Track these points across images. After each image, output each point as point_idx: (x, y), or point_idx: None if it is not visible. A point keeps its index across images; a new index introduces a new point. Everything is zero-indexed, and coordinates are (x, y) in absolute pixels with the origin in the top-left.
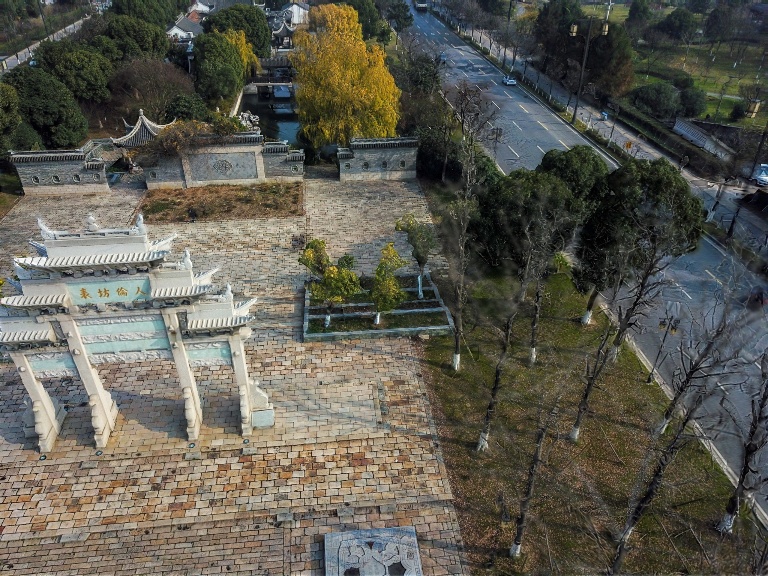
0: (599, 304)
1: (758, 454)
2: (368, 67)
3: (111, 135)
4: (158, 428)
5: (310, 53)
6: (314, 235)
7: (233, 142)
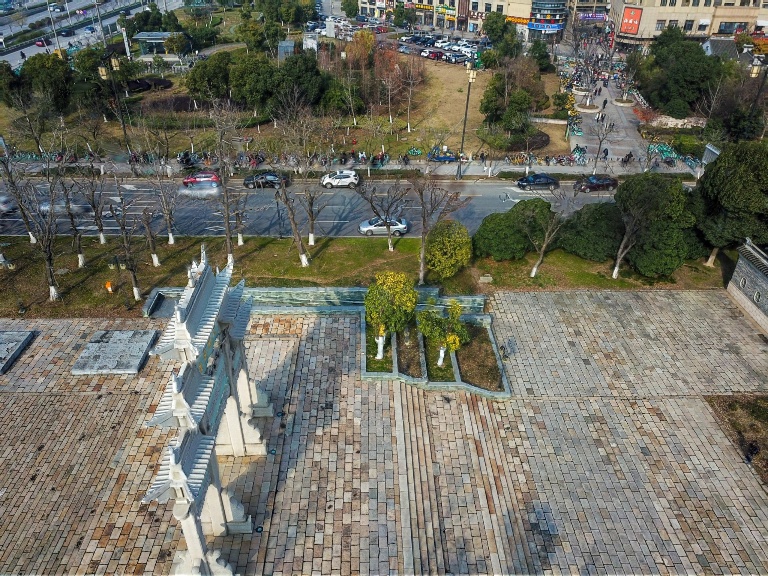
0: None
1: None
2: None
3: None
4: None
5: None
6: None
7: None
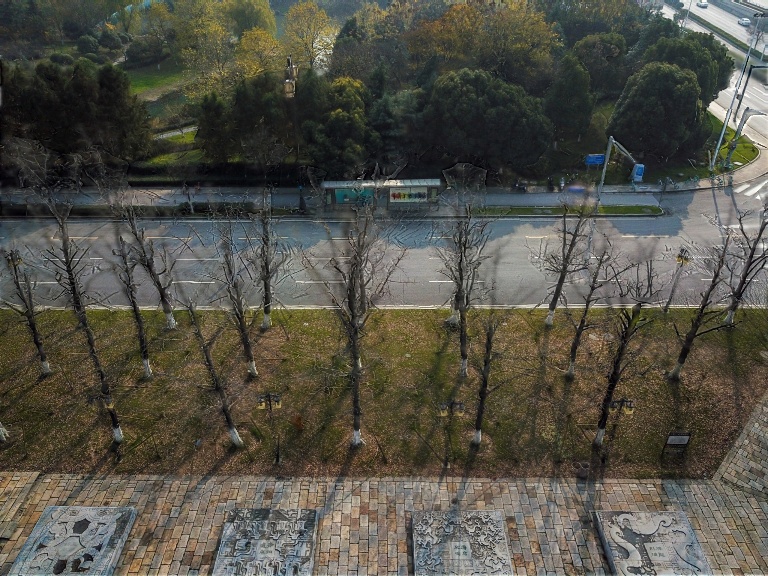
0: None
1: (154, 265)
2: None
3: None
4: None
5: None
6: None
7: None
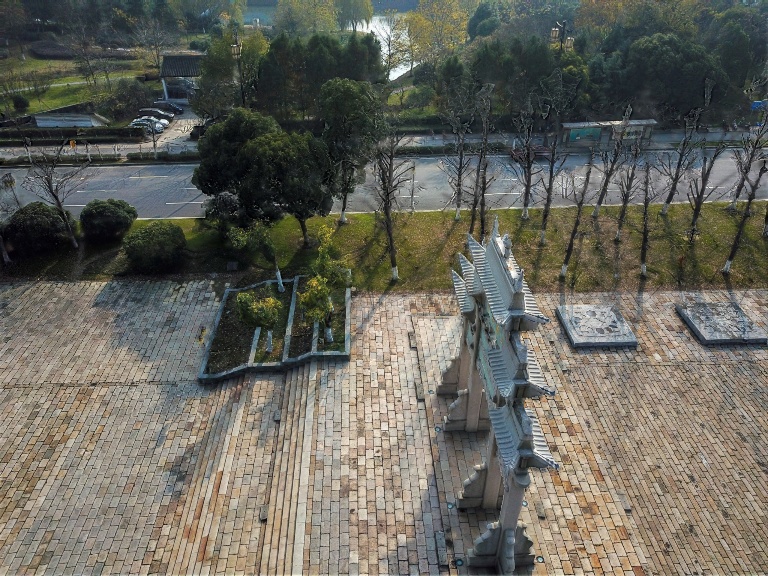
0: None
1: None
2: None
3: None
4: (483, 458)
5: None
6: (65, 379)
7: None
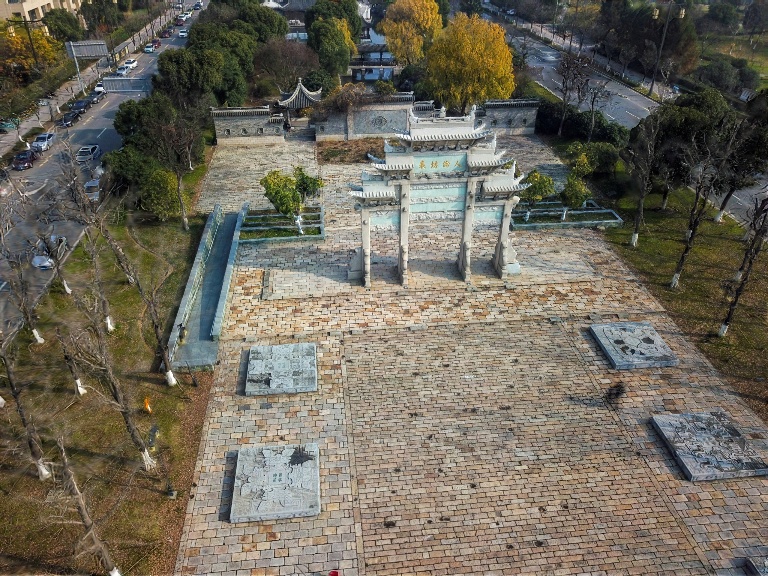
0: (731, 205)
1: None
2: (492, 42)
3: (249, 105)
4: (438, 275)
5: (405, 38)
6: None
7: (391, 101)
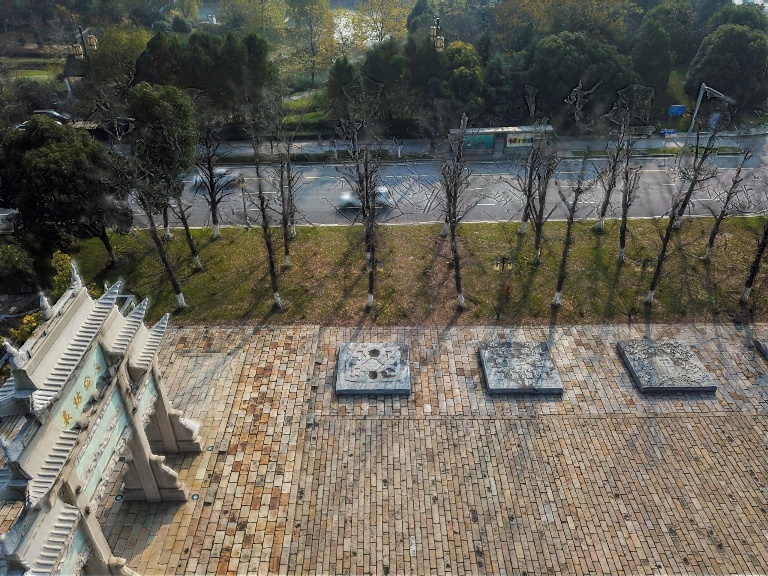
0: None
1: None
2: None
3: None
4: (149, 537)
5: None
6: None
7: None
